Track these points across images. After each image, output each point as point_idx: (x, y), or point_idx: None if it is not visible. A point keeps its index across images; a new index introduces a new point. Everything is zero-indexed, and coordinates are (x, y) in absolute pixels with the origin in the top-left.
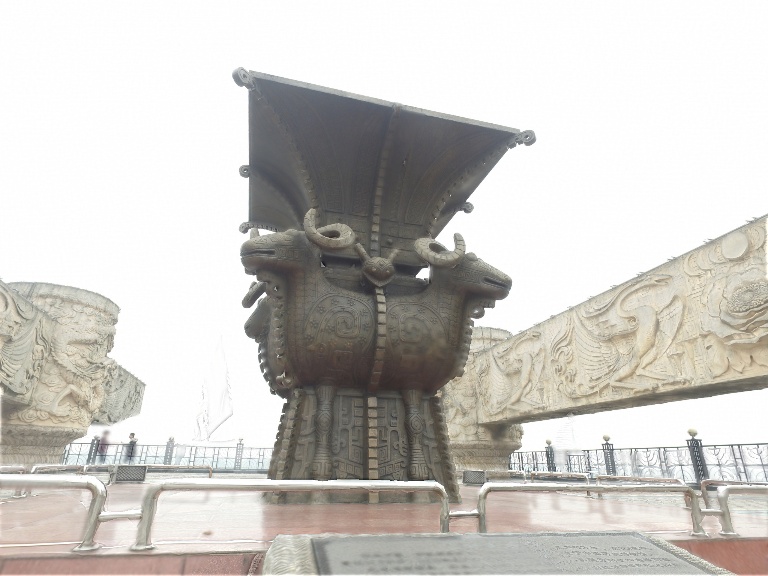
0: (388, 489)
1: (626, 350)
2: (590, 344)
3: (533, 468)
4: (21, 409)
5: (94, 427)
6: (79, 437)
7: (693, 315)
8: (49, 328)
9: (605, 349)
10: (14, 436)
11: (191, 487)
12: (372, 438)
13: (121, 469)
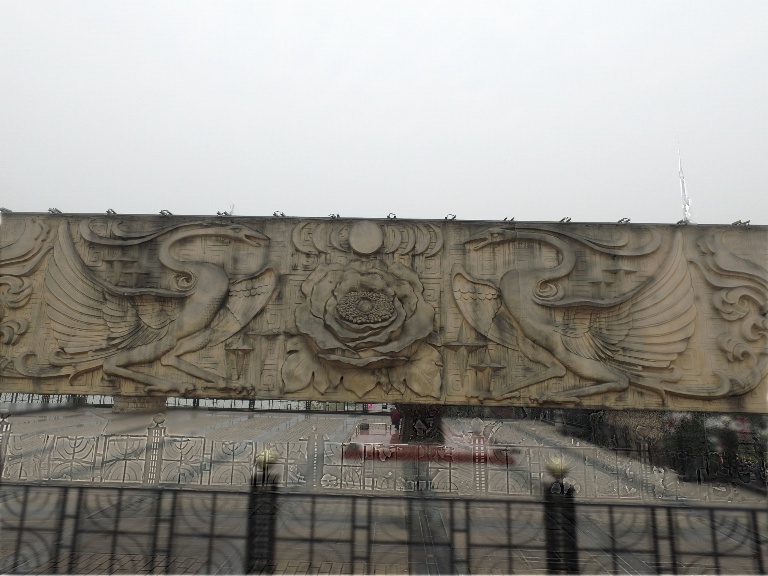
0: None
1: (157, 321)
2: (82, 290)
3: None
4: None
5: None
6: None
7: (283, 303)
8: None
9: (113, 308)
10: None
11: None
12: None
13: None
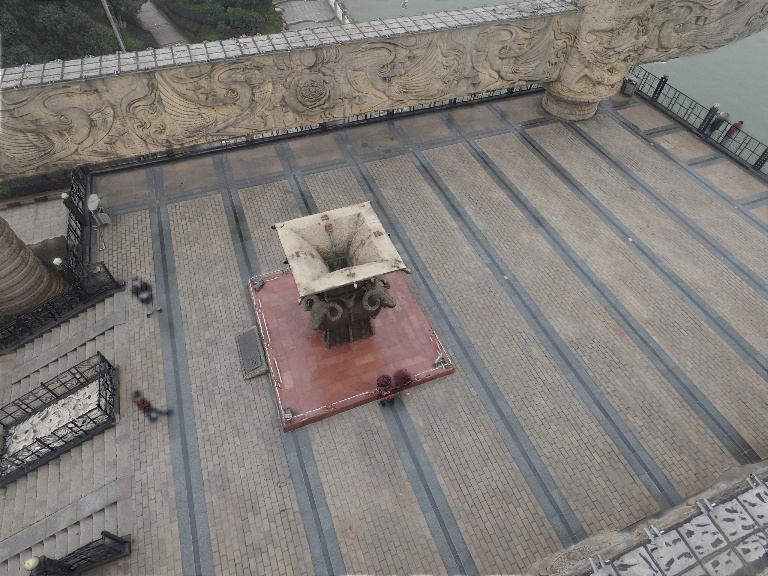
0: None
1: None
2: None
3: (407, 377)
4: (555, 81)
5: (670, 64)
6: None
7: None
8: (573, 20)
9: None
10: None
11: None
12: None
13: None
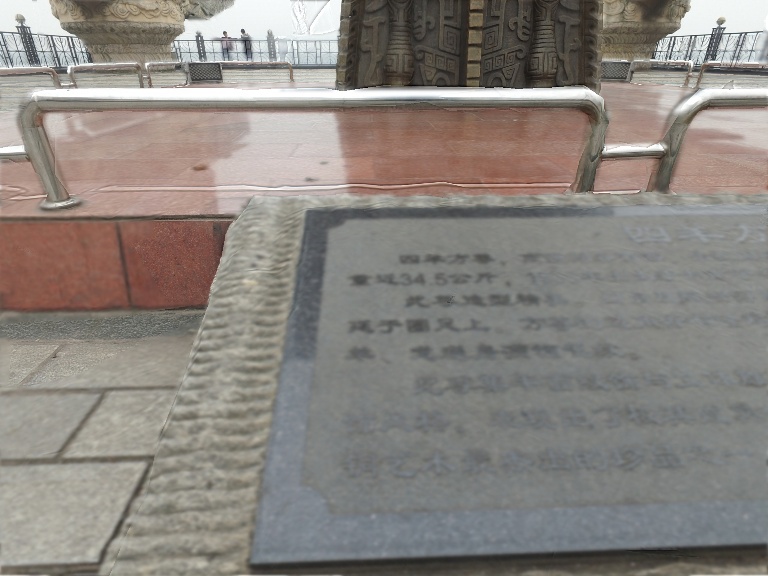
0: (480, 105)
1: None
2: None
3: None
4: (109, 3)
5: (192, 22)
6: (179, 33)
7: None
8: None
9: None
10: (119, 34)
11: (90, 105)
12: (475, 12)
13: (193, 67)
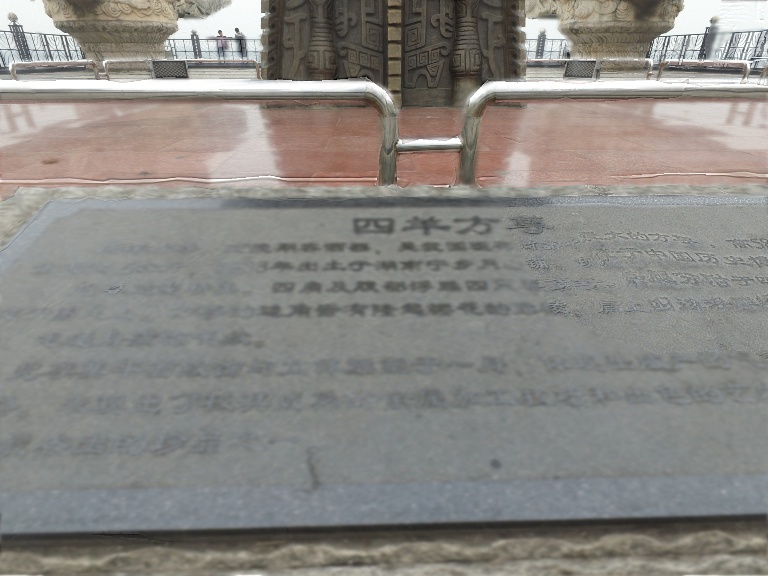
0: (263, 98)
1: None
2: None
3: None
4: (101, 2)
5: (187, 21)
6: (172, 32)
7: None
8: None
9: None
10: (111, 33)
11: None
12: (393, 9)
13: (157, 65)
